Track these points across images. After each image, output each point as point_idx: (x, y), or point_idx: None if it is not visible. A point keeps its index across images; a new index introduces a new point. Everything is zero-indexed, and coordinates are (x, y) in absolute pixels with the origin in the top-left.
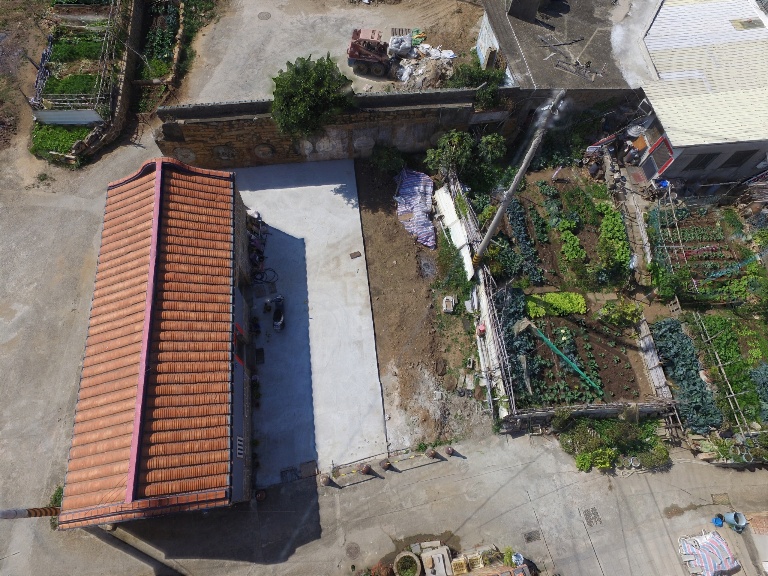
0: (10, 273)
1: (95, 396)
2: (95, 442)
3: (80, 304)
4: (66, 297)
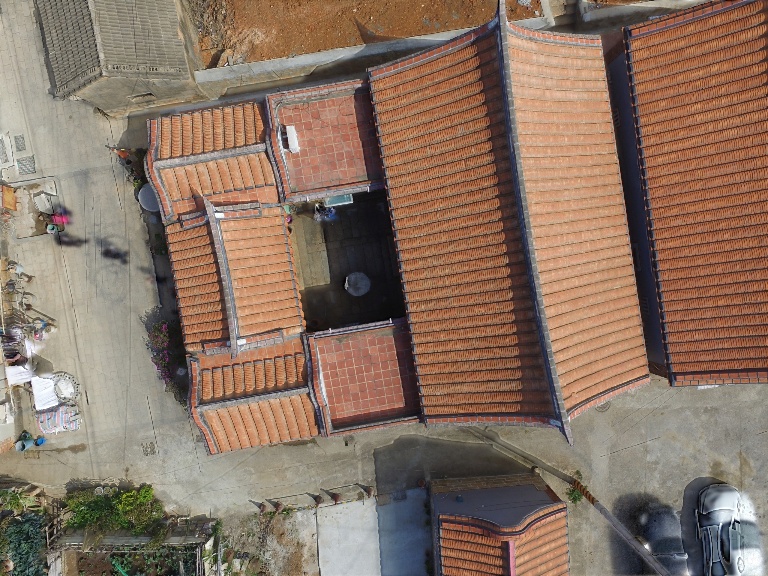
0: None
1: None
2: (549, 571)
3: None
4: None
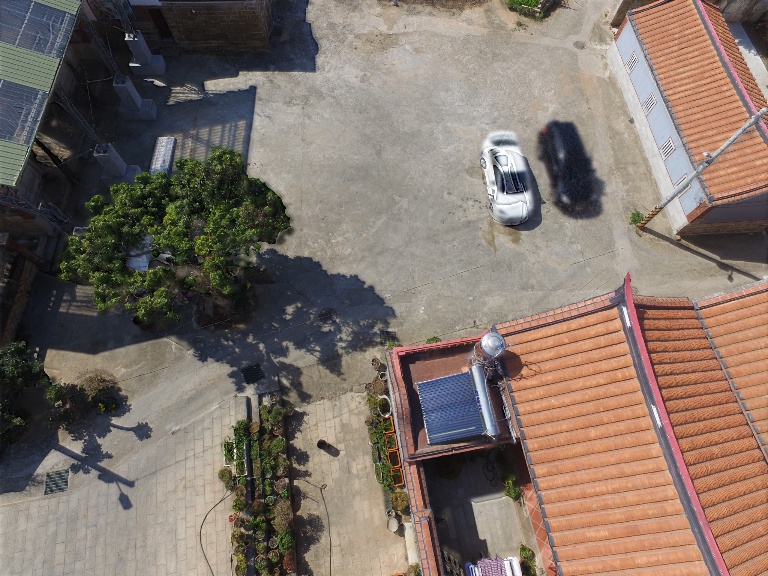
0: (531, 83)
1: (701, 132)
2: (720, 155)
3: (592, 105)
4: (580, 100)
